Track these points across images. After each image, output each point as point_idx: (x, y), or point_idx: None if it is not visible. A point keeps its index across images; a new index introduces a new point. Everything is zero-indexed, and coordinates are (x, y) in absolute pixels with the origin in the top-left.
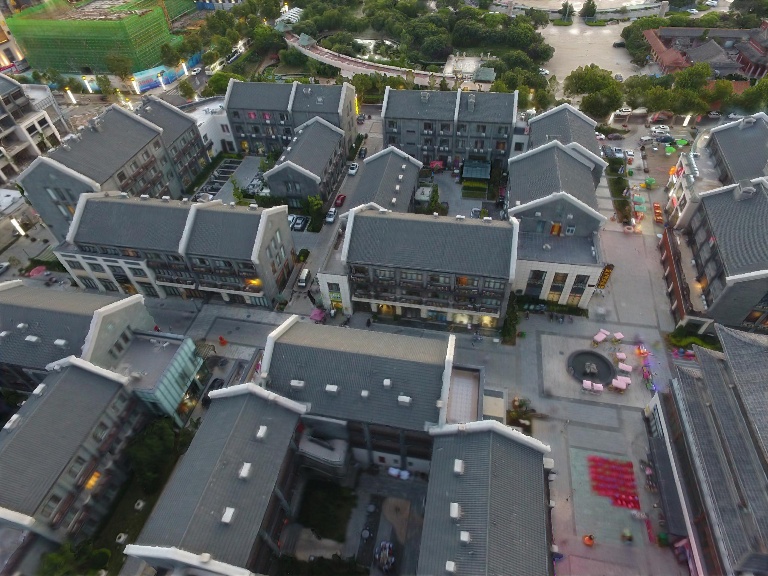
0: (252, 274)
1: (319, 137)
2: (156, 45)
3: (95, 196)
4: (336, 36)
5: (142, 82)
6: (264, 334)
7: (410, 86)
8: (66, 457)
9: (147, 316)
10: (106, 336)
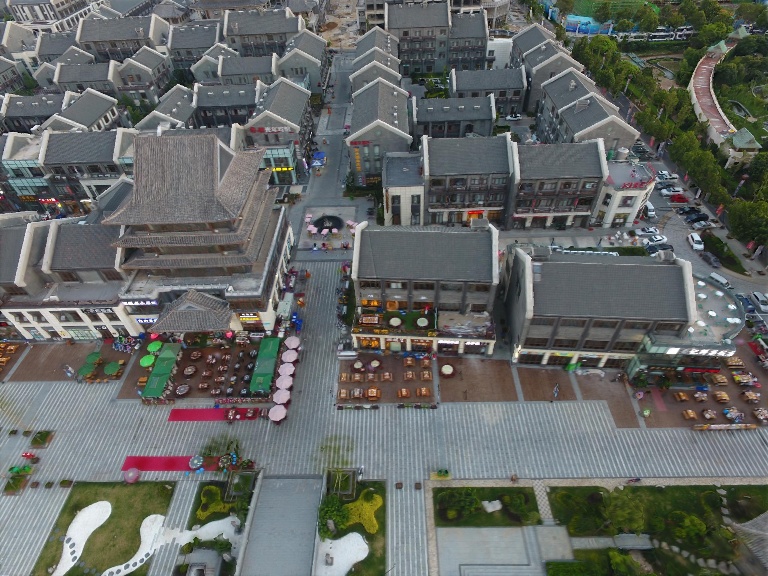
0: (351, 88)
1: (503, 76)
2: (620, 5)
3: (382, 31)
4: (756, 58)
5: (570, 24)
6: (337, 121)
7: (668, 108)
8: (241, 73)
9: (318, 74)
10: (293, 61)
